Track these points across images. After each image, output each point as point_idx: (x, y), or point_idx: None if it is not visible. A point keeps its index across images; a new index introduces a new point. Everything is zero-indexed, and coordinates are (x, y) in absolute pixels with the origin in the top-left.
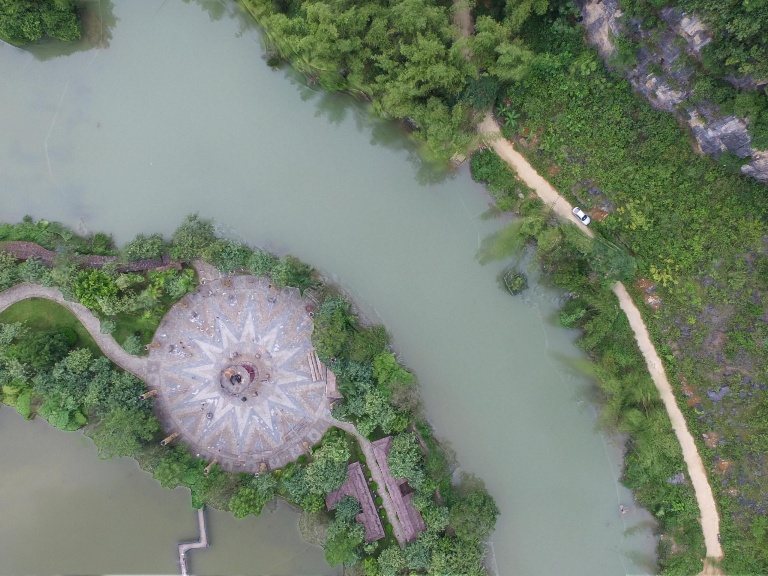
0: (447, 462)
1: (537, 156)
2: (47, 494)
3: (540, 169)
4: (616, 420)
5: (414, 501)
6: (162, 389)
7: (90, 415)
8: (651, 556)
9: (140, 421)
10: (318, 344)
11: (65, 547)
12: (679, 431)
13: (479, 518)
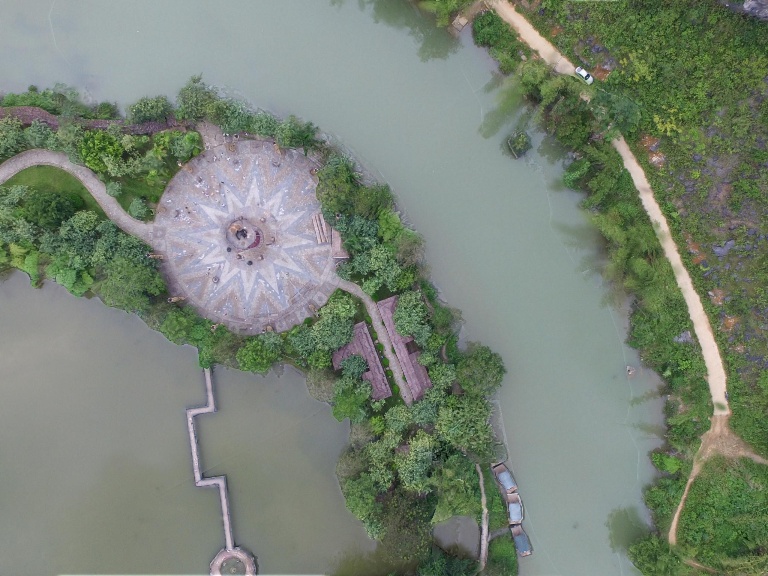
0: (453, 318)
1: (539, 17)
2: (55, 361)
3: (542, 29)
4: (621, 277)
5: (420, 358)
6: (168, 254)
7: (97, 273)
8: (658, 417)
9: (147, 277)
10: (323, 196)
11: (74, 414)
12: (685, 289)
13: (486, 371)
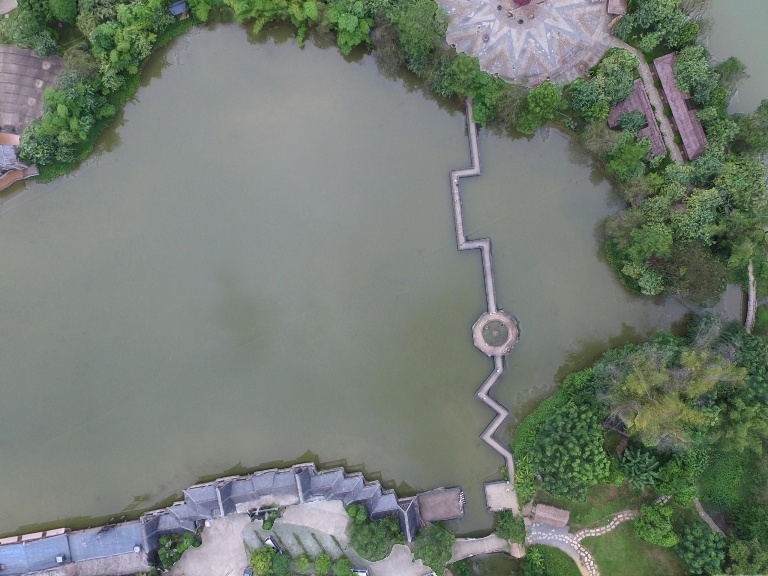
0: (737, 71)
1: None
2: (318, 122)
3: None
4: None
5: (702, 112)
6: (437, 12)
7: (379, 18)
8: None
9: None
10: None
11: (337, 175)
12: None
13: None
